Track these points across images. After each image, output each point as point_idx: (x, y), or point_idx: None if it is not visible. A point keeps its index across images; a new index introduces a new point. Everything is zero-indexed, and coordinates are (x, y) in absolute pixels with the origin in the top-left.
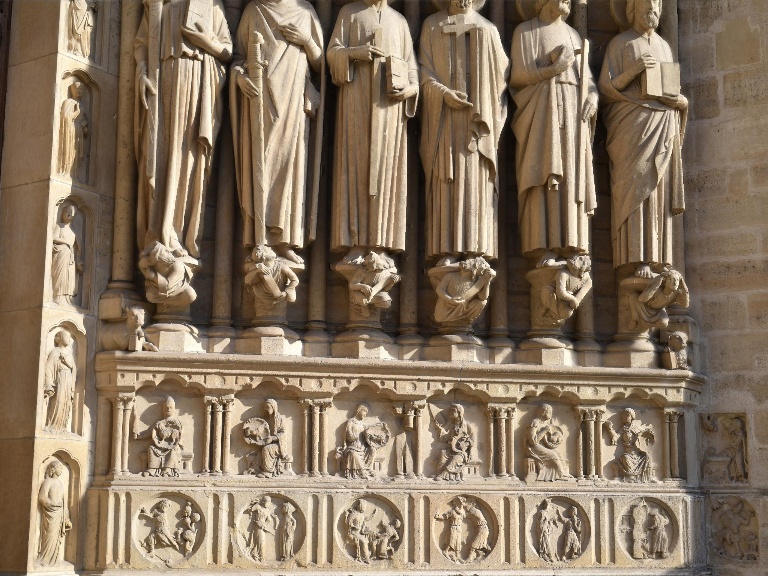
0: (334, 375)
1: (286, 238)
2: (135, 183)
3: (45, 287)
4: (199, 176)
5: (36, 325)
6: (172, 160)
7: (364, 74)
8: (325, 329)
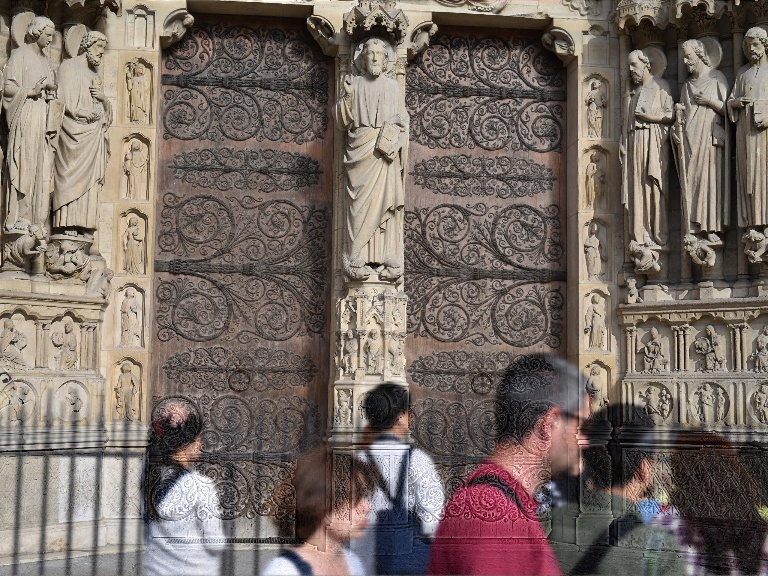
0: (743, 309)
1: (703, 228)
2: None
3: (580, 273)
4: (654, 197)
5: None
6: (634, 192)
7: (743, 115)
8: (748, 279)
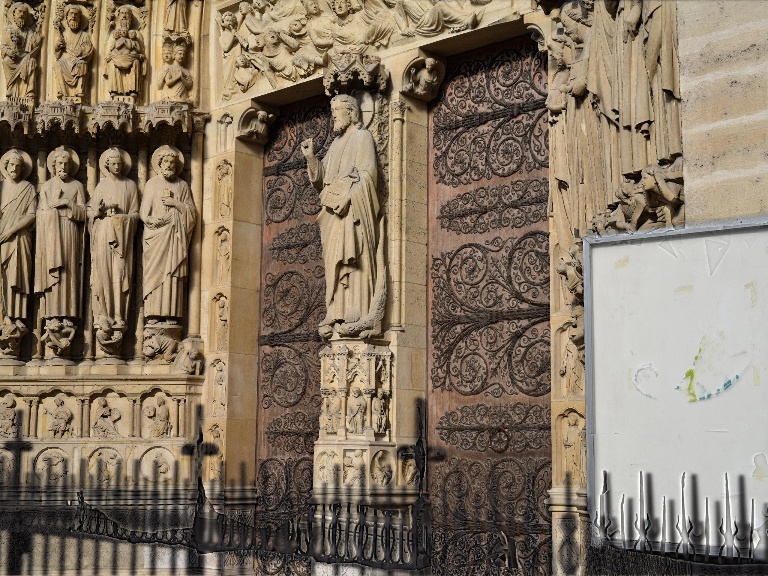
0: None
1: None
2: None
3: (551, 304)
4: None
5: None
6: None
7: None
8: None
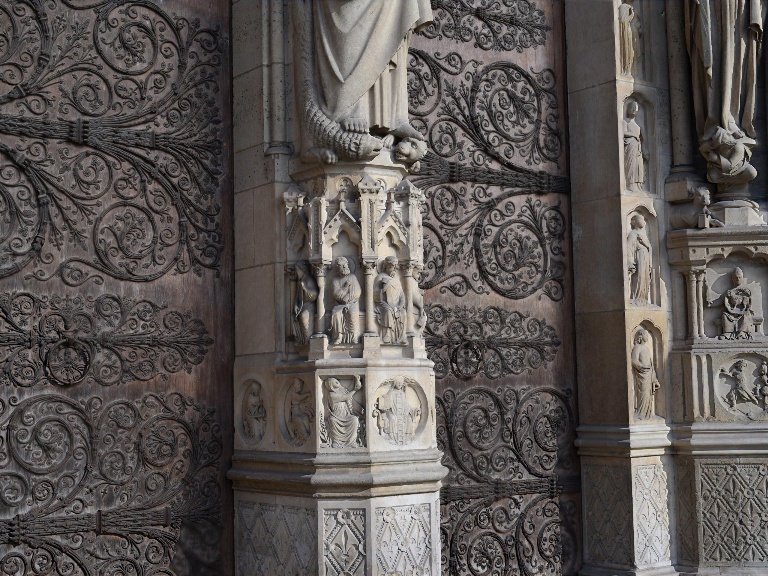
0: None
1: None
2: (688, 74)
3: (621, 177)
4: (752, 61)
5: (616, 211)
6: (727, 49)
7: None
8: None
